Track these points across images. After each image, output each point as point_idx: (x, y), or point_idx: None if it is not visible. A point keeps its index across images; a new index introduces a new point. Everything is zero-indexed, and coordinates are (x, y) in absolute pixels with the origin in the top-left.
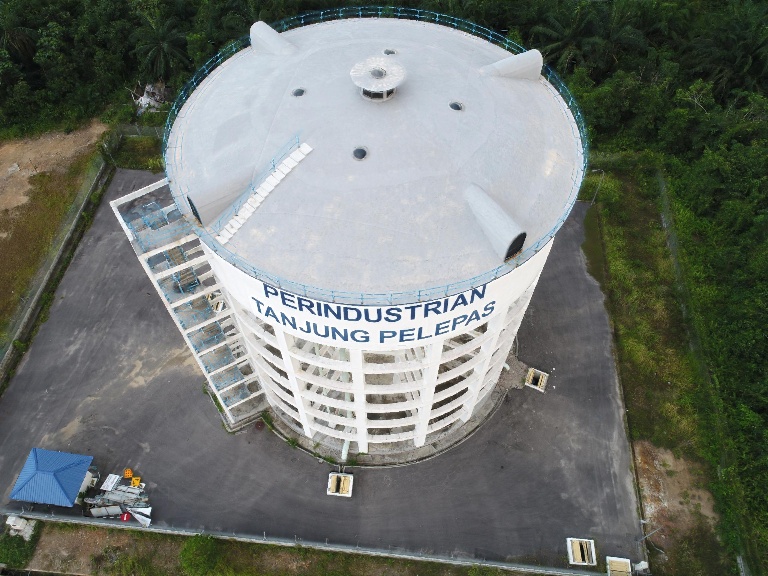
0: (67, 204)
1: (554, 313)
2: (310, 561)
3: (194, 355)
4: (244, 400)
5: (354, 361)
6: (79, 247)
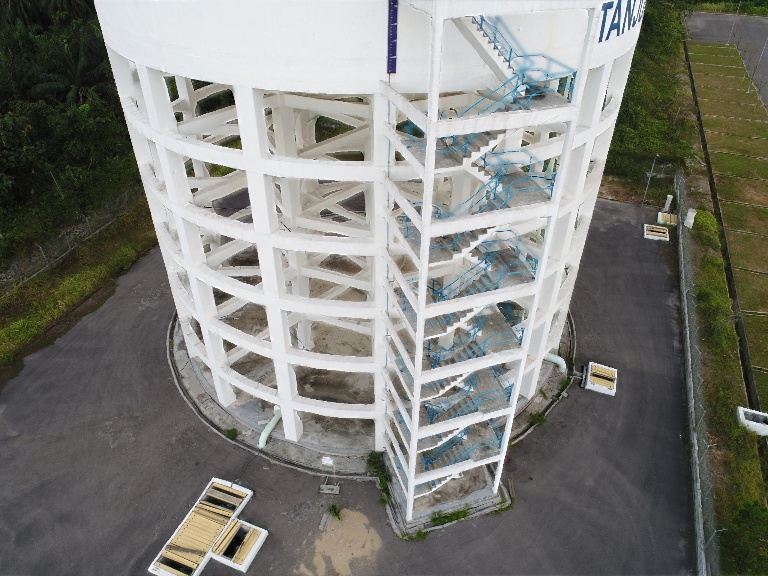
0: None
1: None
2: (707, 433)
3: None
4: None
5: None
6: None
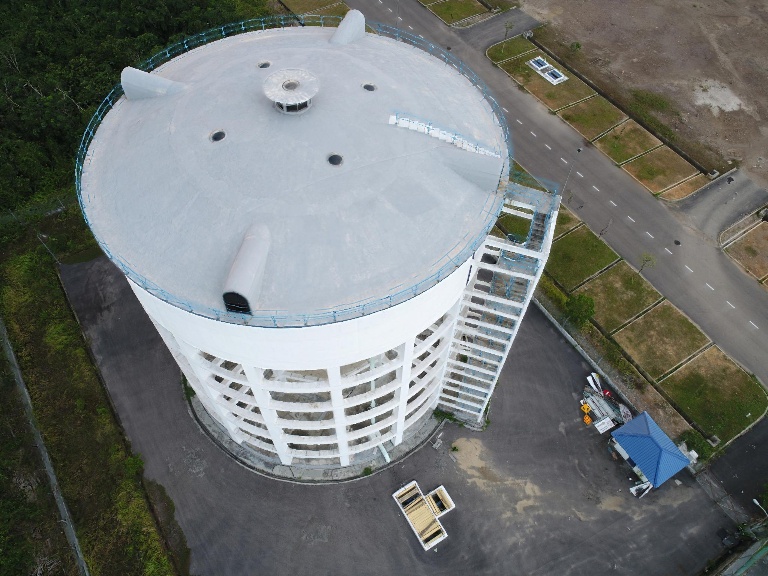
0: None
1: None
2: None
3: None
4: None
5: None
6: None
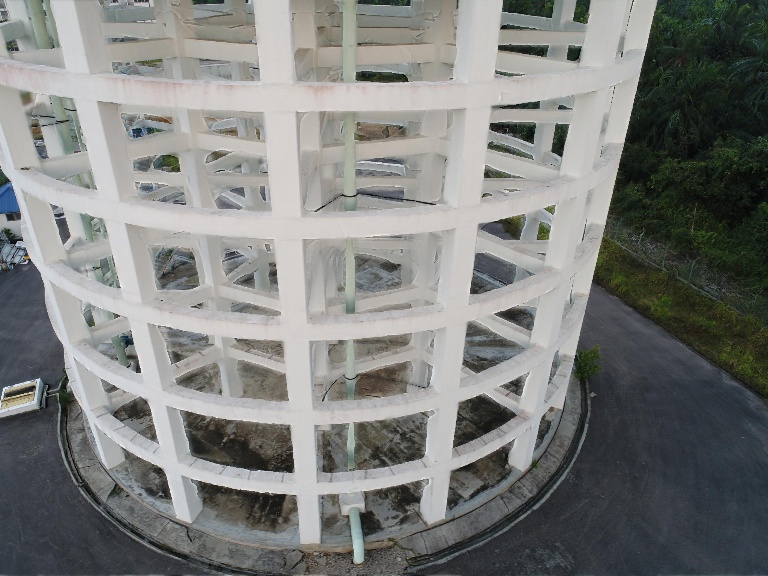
0: None
1: None
2: None
3: None
4: None
5: None
6: None
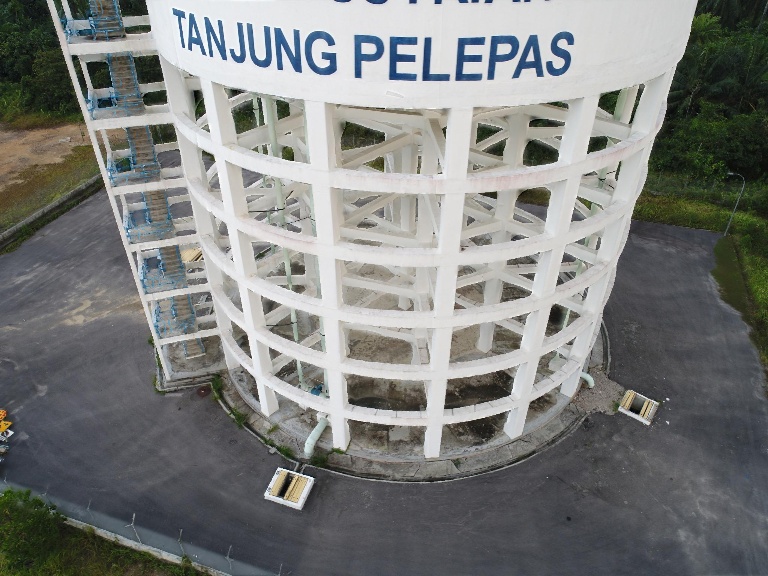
0: (97, 166)
1: (669, 334)
2: None
3: (106, 186)
4: (187, 337)
5: (314, 144)
6: (88, 199)
